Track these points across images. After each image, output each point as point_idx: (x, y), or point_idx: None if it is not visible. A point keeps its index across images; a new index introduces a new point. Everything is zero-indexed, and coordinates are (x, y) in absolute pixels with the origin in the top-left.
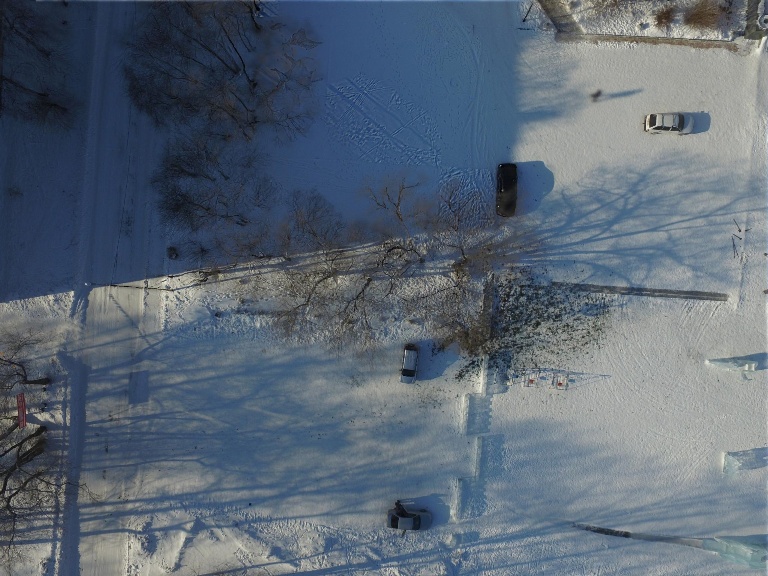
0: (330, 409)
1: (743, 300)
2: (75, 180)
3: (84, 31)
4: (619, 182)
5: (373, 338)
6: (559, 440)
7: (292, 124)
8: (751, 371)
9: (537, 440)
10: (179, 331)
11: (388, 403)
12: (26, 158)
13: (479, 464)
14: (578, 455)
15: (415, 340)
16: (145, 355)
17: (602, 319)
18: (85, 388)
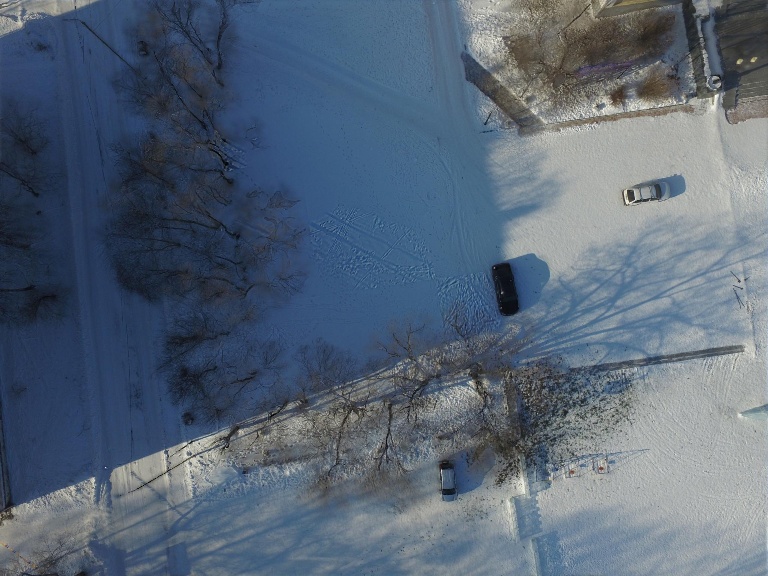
0: (377, 542)
1: (759, 347)
2: (76, 365)
3: (59, 217)
4: (612, 258)
5: (405, 461)
6: (613, 525)
7: (286, 284)
8: None
9: (591, 529)
10: (209, 495)
11: (434, 524)
12: (23, 354)
13: (540, 569)
14: (636, 536)
15: (447, 454)
16: (179, 526)
17: (627, 394)
18: (123, 574)
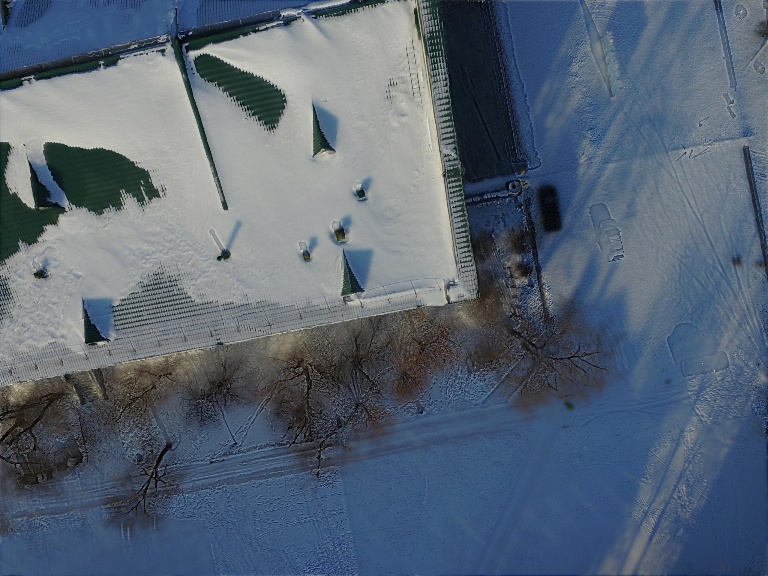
0: None
1: (745, 133)
2: None
3: None
4: (669, 267)
5: None
6: None
7: None
8: None
9: None
10: None
11: None
12: None
13: None
14: None
15: None
16: None
17: None
18: None
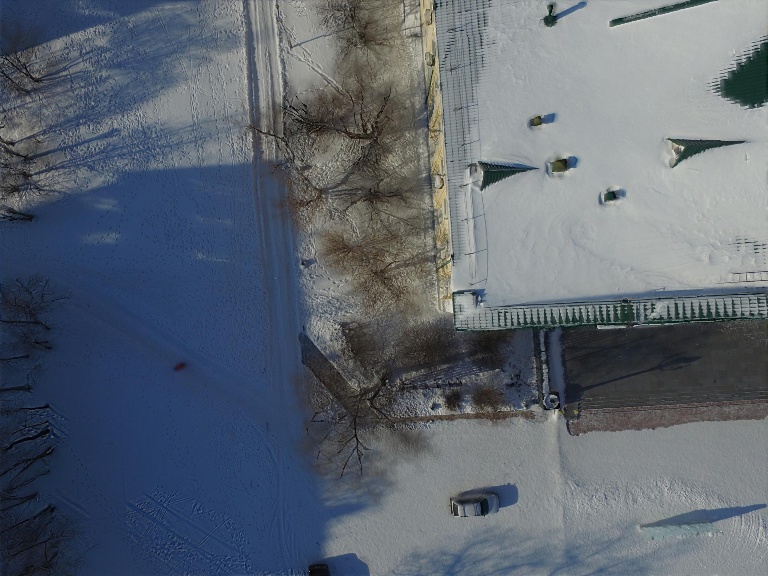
0: None
1: None
2: None
3: None
4: (435, 565)
5: None
6: None
7: None
8: None
9: None
10: None
11: None
12: None
13: None
14: None
15: None
16: None
17: None
18: None
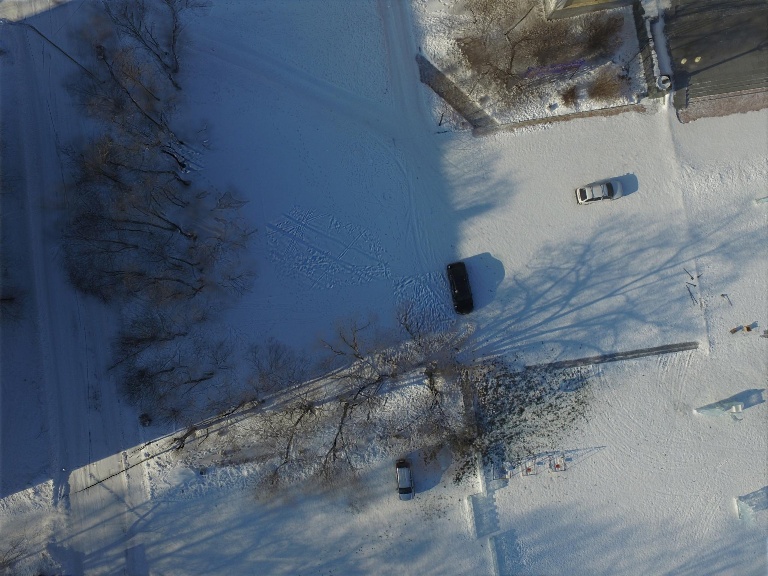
0: (335, 542)
1: (713, 344)
2: (34, 367)
3: (18, 220)
4: (566, 256)
5: (363, 461)
6: (571, 522)
7: (236, 284)
8: (739, 413)
9: (549, 527)
10: (167, 496)
11: (392, 523)
12: None
13: (497, 567)
14: (593, 533)
15: (405, 453)
16: (137, 528)
17: (583, 392)
18: None
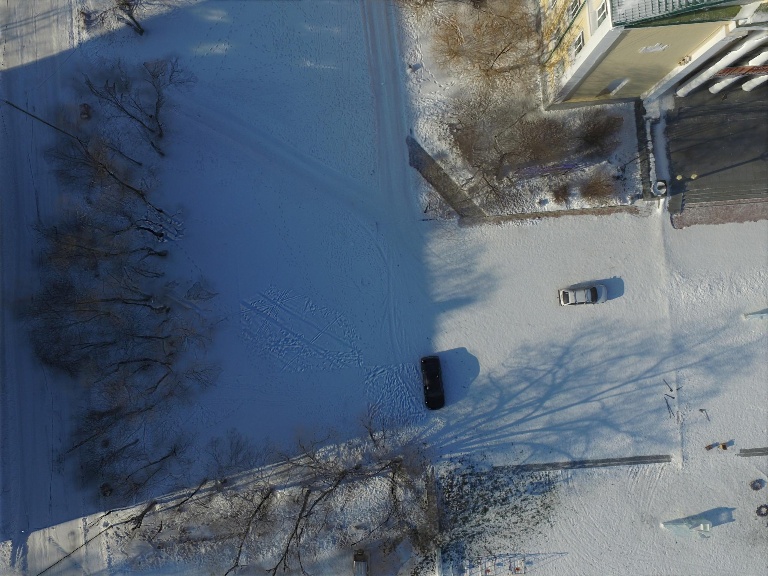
0: None
1: (687, 459)
2: None
3: None
4: (544, 358)
5: (322, 547)
6: None
7: (199, 377)
8: (707, 532)
9: None
10: (124, 566)
11: None
12: None
13: None
14: None
15: (365, 543)
16: None
17: (549, 496)
18: None
